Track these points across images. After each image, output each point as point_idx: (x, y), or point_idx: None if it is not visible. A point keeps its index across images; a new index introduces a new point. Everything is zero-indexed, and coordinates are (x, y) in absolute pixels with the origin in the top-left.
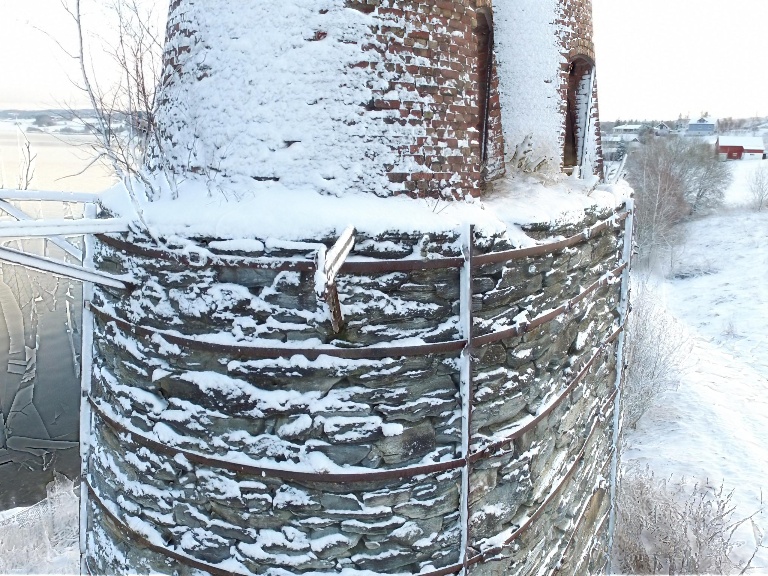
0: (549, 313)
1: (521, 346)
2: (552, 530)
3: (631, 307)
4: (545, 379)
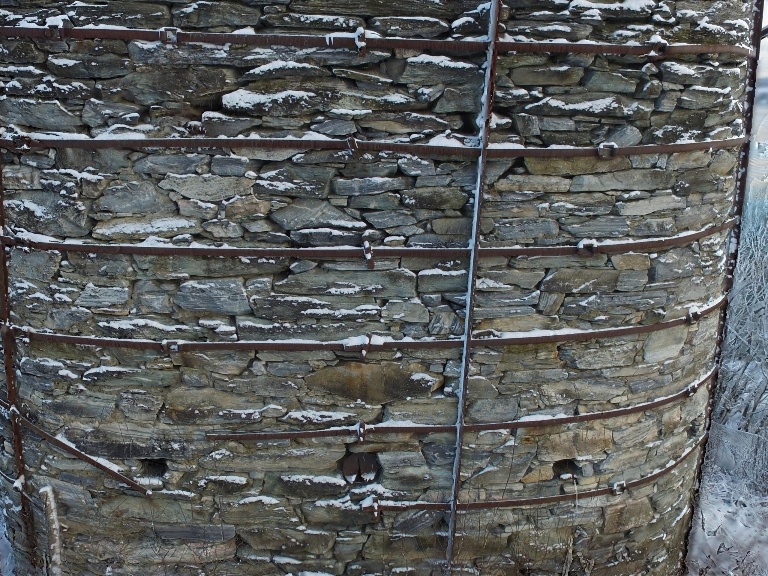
0: (113, 29)
1: (67, 55)
2: (164, 302)
3: (599, 148)
4: (120, 109)
